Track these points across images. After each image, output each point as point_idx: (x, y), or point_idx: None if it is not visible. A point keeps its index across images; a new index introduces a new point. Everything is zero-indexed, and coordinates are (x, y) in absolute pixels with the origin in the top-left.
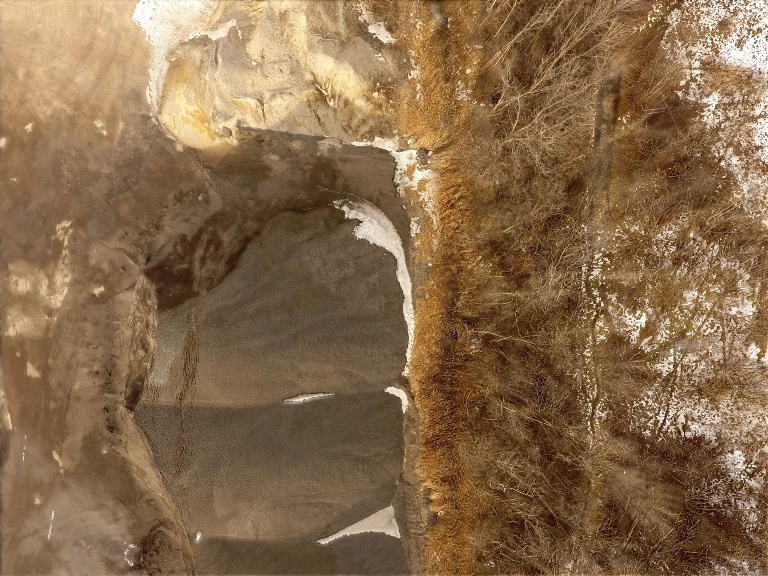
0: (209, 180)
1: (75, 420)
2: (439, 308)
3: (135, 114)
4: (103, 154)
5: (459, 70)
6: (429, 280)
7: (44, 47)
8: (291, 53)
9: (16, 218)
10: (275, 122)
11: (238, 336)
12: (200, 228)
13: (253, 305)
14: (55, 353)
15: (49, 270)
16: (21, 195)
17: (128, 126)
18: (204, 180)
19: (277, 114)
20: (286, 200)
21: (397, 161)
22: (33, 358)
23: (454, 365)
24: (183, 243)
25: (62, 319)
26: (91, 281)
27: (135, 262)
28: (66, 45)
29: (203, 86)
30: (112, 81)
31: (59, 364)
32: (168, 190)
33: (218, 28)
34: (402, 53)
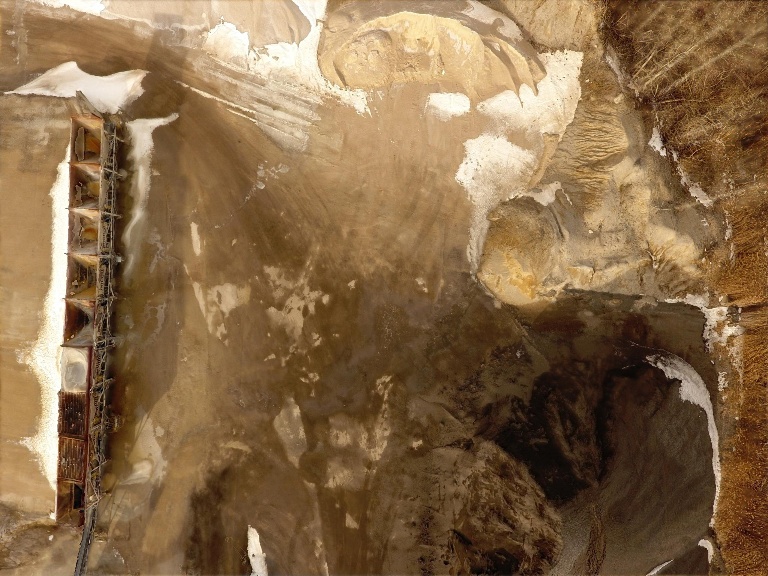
0: (527, 337)
1: (391, 569)
2: (744, 460)
3: (456, 272)
4: (423, 311)
5: (766, 227)
6: (736, 433)
7: (368, 206)
8: (627, 222)
9: (337, 373)
10: (601, 285)
11: (635, 530)
12: (534, 392)
13: (640, 495)
14: (373, 504)
15: (369, 424)
16: (343, 350)
17: (448, 283)
18: (521, 336)
19: (606, 279)
20: (607, 359)
21: (707, 317)
22: (352, 509)
23: (758, 516)
24: (523, 409)
25: (381, 471)
26: (410, 435)
27: (457, 418)
28: (390, 204)
29: (546, 257)
30: (434, 240)
31: (377, 515)
32: (486, 346)
33: (542, 190)
34: (720, 215)
